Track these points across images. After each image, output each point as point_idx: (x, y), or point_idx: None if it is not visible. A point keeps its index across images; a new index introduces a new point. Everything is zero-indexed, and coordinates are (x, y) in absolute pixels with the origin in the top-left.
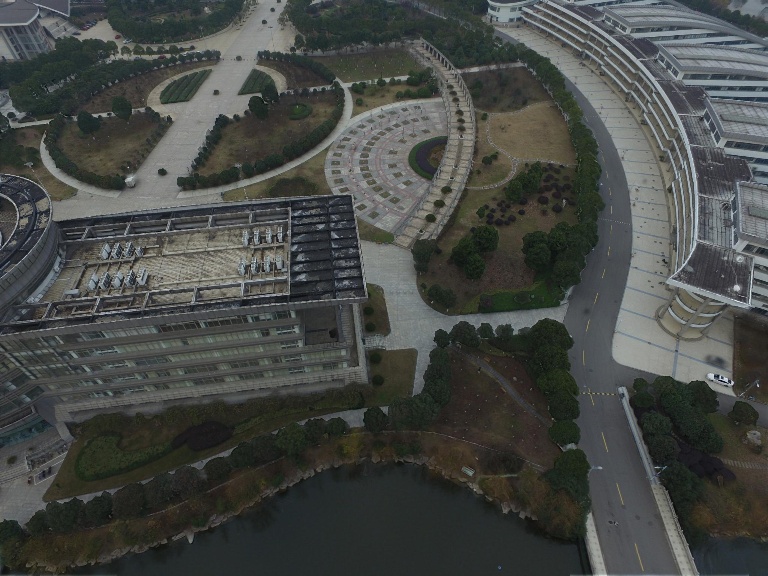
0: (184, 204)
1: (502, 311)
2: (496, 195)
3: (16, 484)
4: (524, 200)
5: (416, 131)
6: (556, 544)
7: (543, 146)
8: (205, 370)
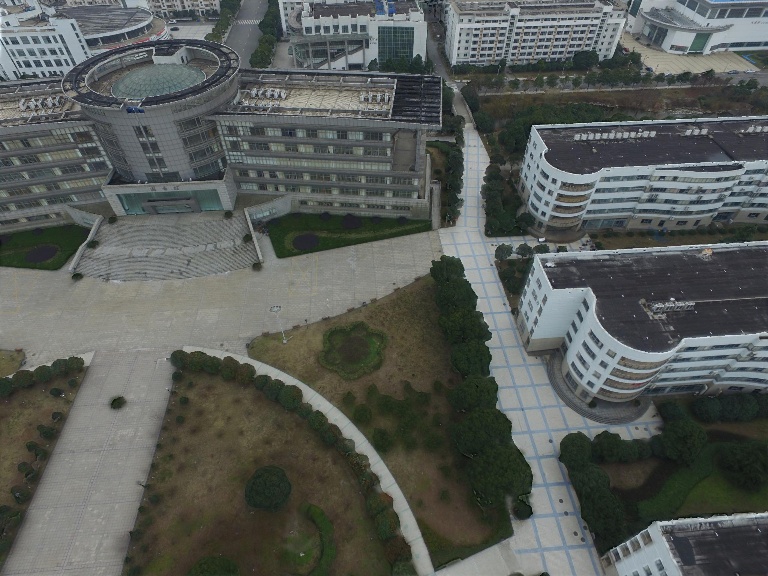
0: (83, 341)
1: None
2: None
3: None
4: None
5: None
6: None
7: None
8: None
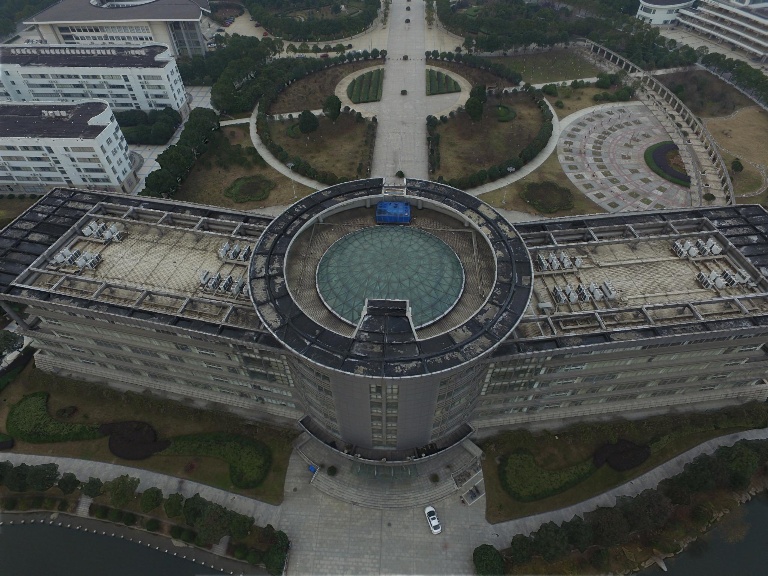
0: None
1: None
2: (764, 203)
3: (449, 504)
4: None
5: (636, 135)
6: None
7: None
8: (633, 387)
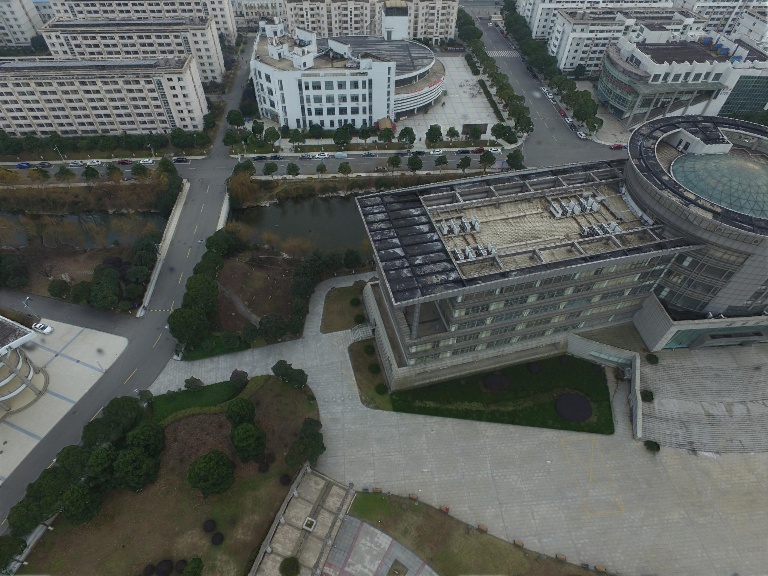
0: (764, 567)
1: None
2: None
3: None
4: None
5: None
6: None
7: None
8: None
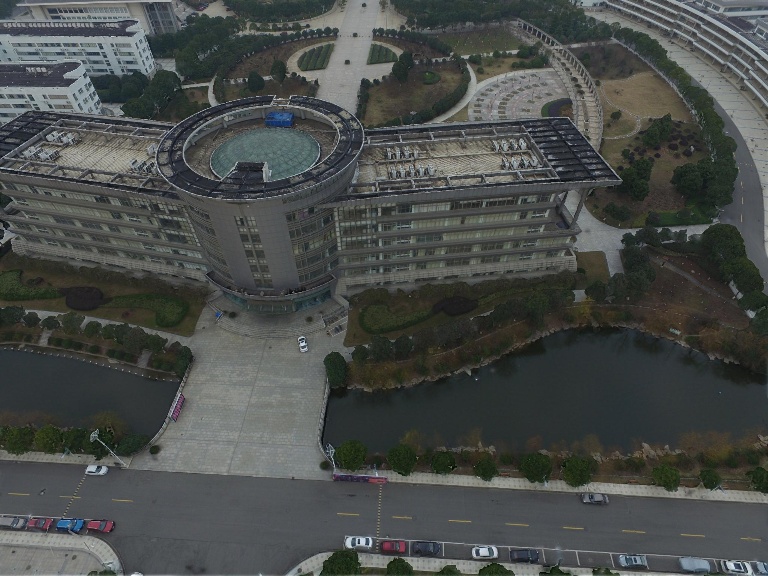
0: None
1: (666, 226)
2: (630, 143)
3: (318, 336)
4: (658, 146)
5: (540, 94)
6: (752, 385)
7: (658, 106)
8: (461, 251)
